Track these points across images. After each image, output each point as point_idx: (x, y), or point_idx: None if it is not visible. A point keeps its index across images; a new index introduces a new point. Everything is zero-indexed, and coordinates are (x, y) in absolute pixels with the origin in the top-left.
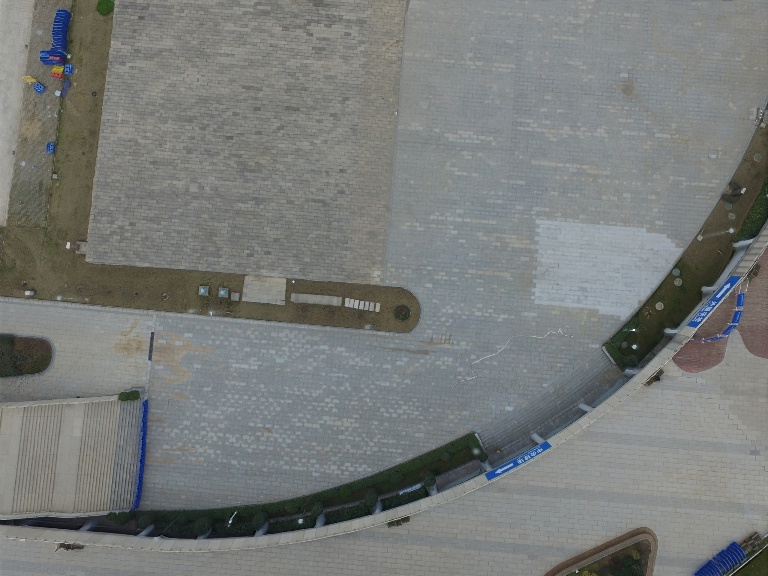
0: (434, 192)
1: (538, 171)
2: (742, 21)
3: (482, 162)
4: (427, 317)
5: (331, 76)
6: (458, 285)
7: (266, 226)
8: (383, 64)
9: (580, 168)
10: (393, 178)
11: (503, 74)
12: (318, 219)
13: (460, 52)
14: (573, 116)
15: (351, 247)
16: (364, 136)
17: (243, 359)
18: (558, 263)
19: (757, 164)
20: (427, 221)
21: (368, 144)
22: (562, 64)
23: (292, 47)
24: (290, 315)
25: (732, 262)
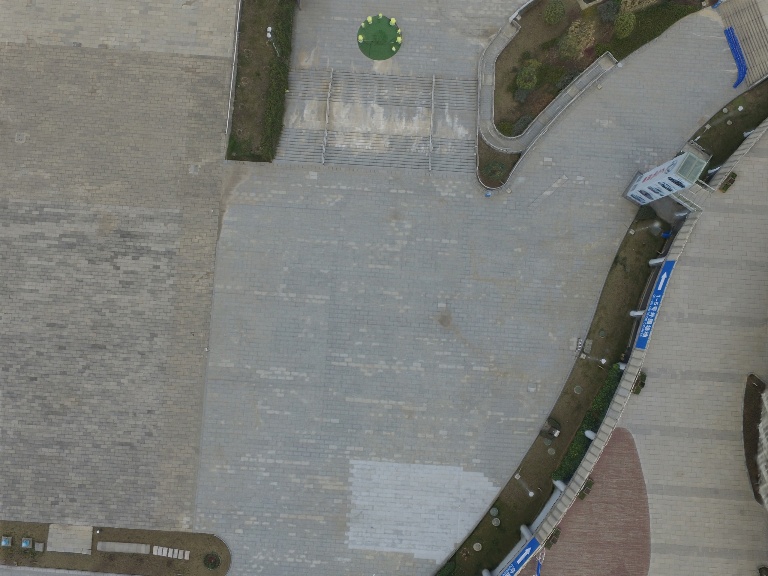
0: (245, 432)
1: (352, 408)
2: (563, 246)
3: (295, 400)
4: (238, 564)
5: (139, 311)
6: (269, 530)
7: (71, 472)
8: (193, 298)
9: (395, 404)
10: (203, 418)
11: (317, 306)
12: (125, 463)
13: (273, 283)
14: (389, 349)
15: (159, 492)
16: (173, 374)
17: None
18: (372, 505)
19: (577, 396)
20: (238, 463)
21: (177, 383)
22: (378, 294)
23: (98, 281)
24: (97, 564)
25: (551, 500)
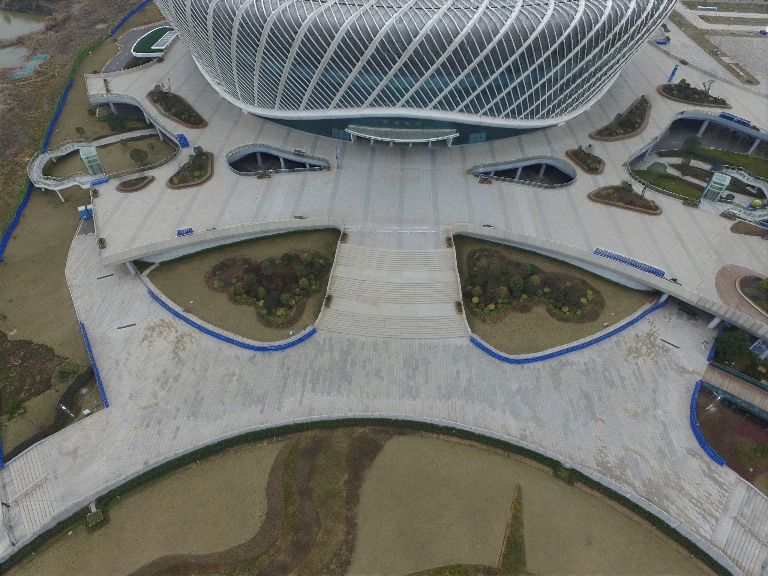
0: None
1: None
2: None
3: None
4: (754, 86)
5: None
6: None
7: None
8: None
9: None
10: None
11: None
12: None
13: None
14: None
15: (763, 73)
16: None
17: None
18: None
19: None
20: None
21: None
22: None
23: None
24: None
25: None
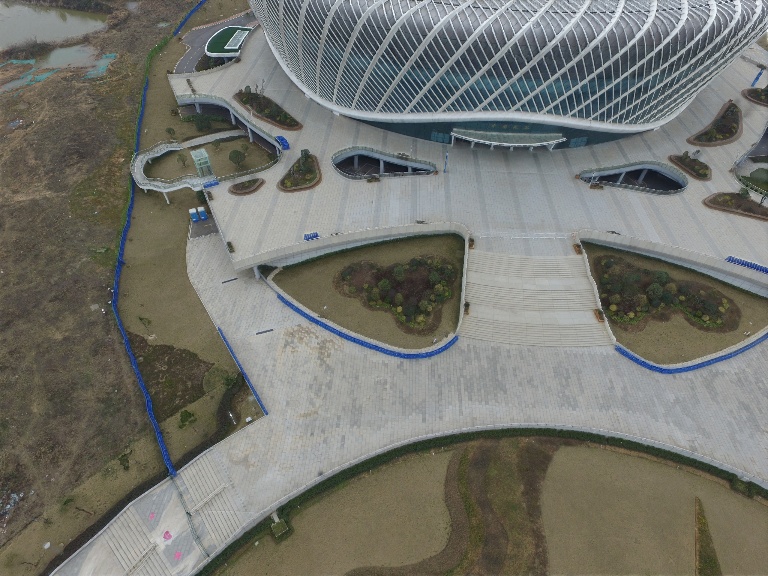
0: None
1: None
2: None
3: None
4: None
5: None
6: None
7: None
8: None
9: None
10: None
11: None
12: None
13: None
14: None
15: None
16: None
17: (767, 61)
18: None
19: None
20: None
21: None
22: None
23: None
24: None
25: None
